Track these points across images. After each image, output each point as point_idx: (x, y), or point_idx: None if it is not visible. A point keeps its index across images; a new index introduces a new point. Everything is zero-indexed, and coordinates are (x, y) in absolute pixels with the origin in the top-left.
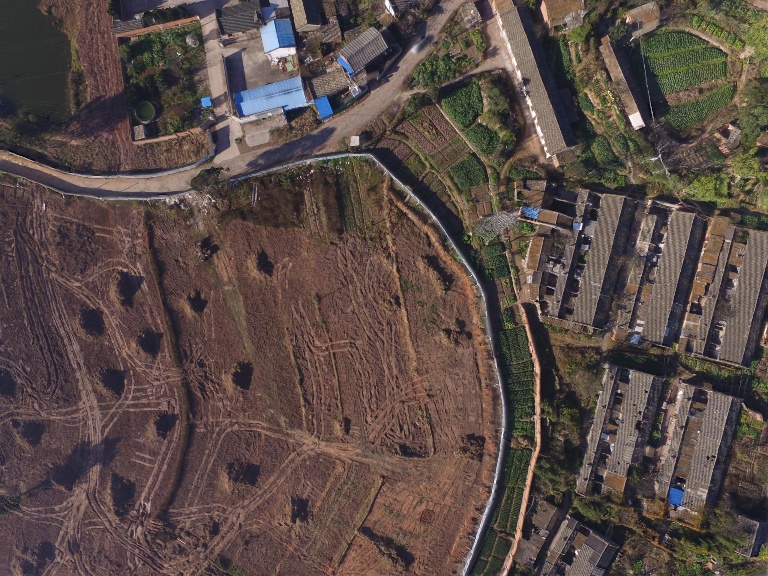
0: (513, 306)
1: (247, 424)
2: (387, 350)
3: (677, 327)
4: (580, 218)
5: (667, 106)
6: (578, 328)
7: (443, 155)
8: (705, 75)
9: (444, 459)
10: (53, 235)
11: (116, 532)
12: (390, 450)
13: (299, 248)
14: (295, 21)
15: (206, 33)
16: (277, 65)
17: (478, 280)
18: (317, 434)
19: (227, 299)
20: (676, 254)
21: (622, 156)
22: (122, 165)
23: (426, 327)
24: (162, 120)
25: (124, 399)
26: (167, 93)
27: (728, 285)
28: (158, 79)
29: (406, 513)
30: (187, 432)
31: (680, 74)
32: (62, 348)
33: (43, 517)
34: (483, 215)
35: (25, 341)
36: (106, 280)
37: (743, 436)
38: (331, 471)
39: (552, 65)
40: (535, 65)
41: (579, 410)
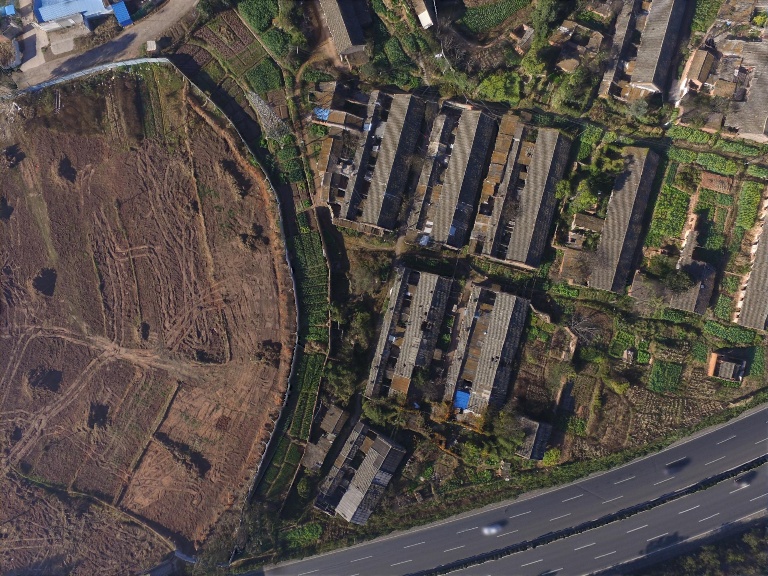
0: (308, 210)
1: (51, 331)
2: (186, 256)
3: (466, 228)
4: (370, 119)
5: (464, 8)
6: (368, 230)
7: (241, 60)
8: None
9: (241, 365)
10: None
11: None
12: (188, 356)
13: (101, 154)
14: None
15: None
16: None
17: (274, 184)
18: (117, 340)
19: (32, 206)
20: (463, 153)
21: (413, 56)
22: None
23: (223, 232)
24: None
25: None
26: None
27: (518, 185)
28: None
29: (202, 419)
30: None
31: None
32: None
33: None
34: None
35: None
36: None
37: (533, 339)
38: (131, 377)
39: None
40: None
41: (371, 314)
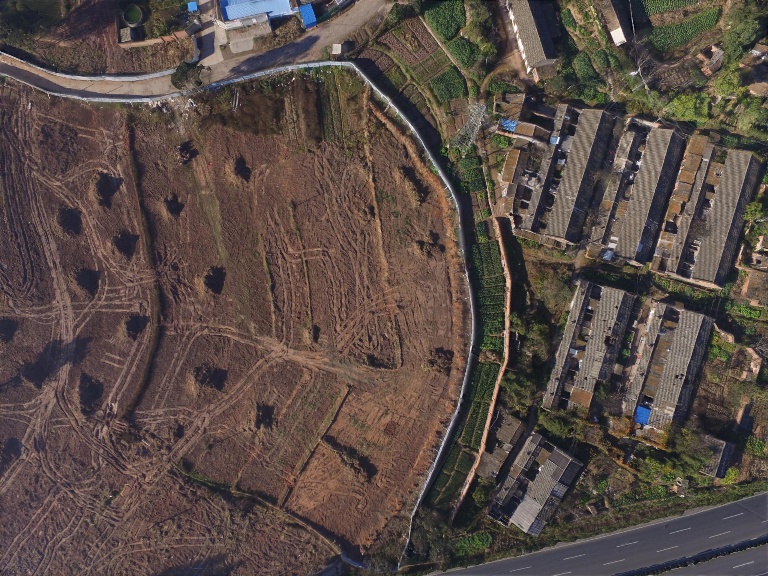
0: (487, 220)
1: (217, 329)
2: (359, 260)
3: (651, 245)
4: (557, 132)
5: (651, 27)
6: (551, 242)
7: (424, 67)
8: None
9: (411, 371)
10: (37, 134)
11: (82, 431)
12: (358, 360)
13: (277, 155)
14: None
15: None
16: None
17: (453, 193)
18: (286, 341)
19: (204, 203)
20: (652, 170)
21: (602, 72)
22: (108, 68)
23: (399, 238)
24: (149, 24)
25: (97, 299)
26: None
27: (704, 205)
28: None
29: (371, 424)
30: (157, 334)
31: None
32: (39, 246)
33: (11, 414)
34: None
35: (4, 238)
36: (86, 181)
37: (714, 358)
38: (298, 379)
39: None
40: None
41: (549, 326)
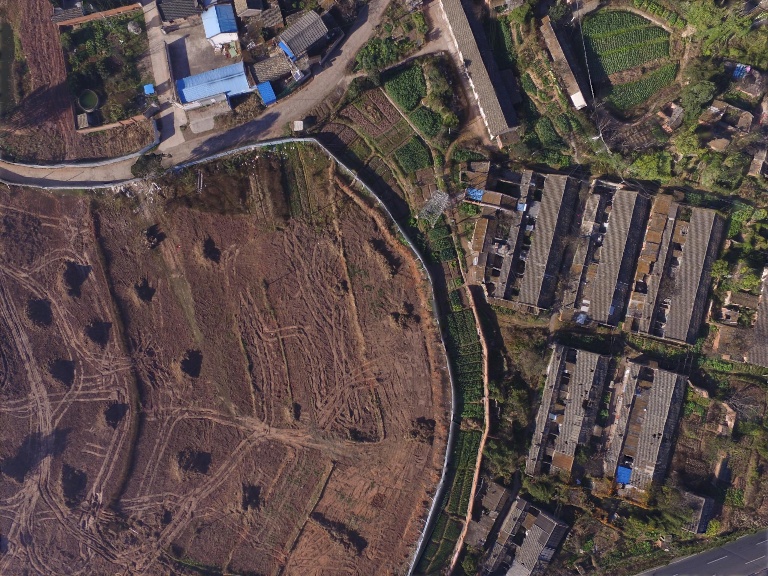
0: (460, 288)
1: (197, 412)
2: (336, 335)
3: (622, 306)
4: (524, 199)
5: (610, 86)
6: (524, 309)
7: (388, 138)
8: (648, 54)
9: (395, 443)
10: None
11: (68, 523)
12: (340, 435)
13: (246, 234)
14: (236, 6)
15: (149, 20)
16: (221, 51)
17: (425, 263)
18: (267, 421)
19: (175, 287)
20: (620, 233)
21: (565, 136)
22: (67, 154)
23: (374, 311)
24: (106, 108)
25: (74, 389)
26: (110, 81)
27: (672, 263)
28: (100, 67)
29: (357, 498)
30: (137, 421)
31: (623, 54)
32: (10, 339)
33: None
34: (429, 198)
35: None
36: (53, 270)
37: (690, 413)
38: (282, 457)
39: (491, 45)
40: (475, 46)
41: (527, 391)
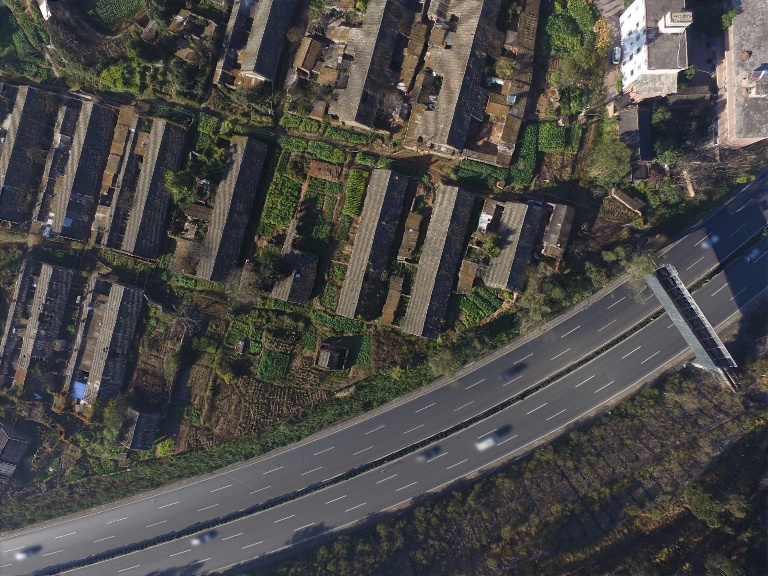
0: None
1: None
2: None
3: (87, 219)
4: None
5: None
6: None
7: None
8: None
9: None
10: None
11: None
12: None
13: None
14: None
15: None
16: None
17: None
18: None
19: None
20: (79, 144)
21: (39, 48)
22: None
23: None
24: None
25: None
26: None
27: (137, 176)
28: None
29: None
30: None
31: None
32: None
33: None
34: None
35: None
36: None
37: (152, 330)
38: None
39: None
40: None
41: (2, 306)
